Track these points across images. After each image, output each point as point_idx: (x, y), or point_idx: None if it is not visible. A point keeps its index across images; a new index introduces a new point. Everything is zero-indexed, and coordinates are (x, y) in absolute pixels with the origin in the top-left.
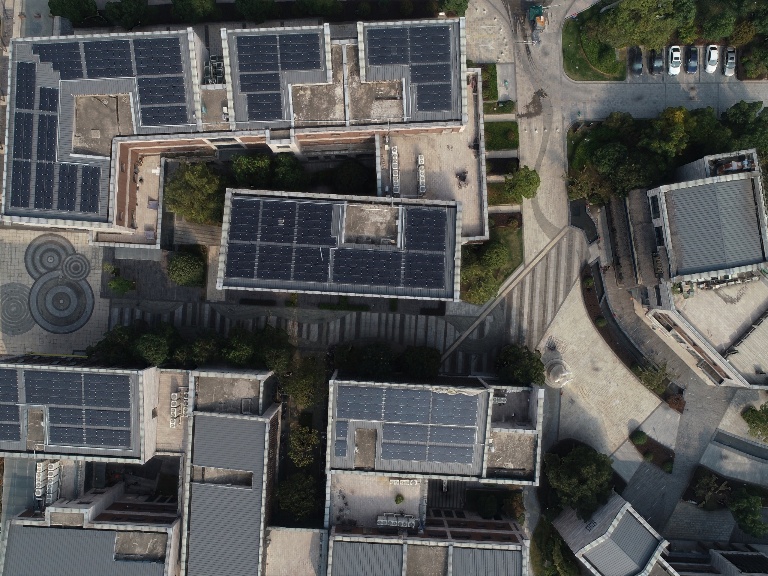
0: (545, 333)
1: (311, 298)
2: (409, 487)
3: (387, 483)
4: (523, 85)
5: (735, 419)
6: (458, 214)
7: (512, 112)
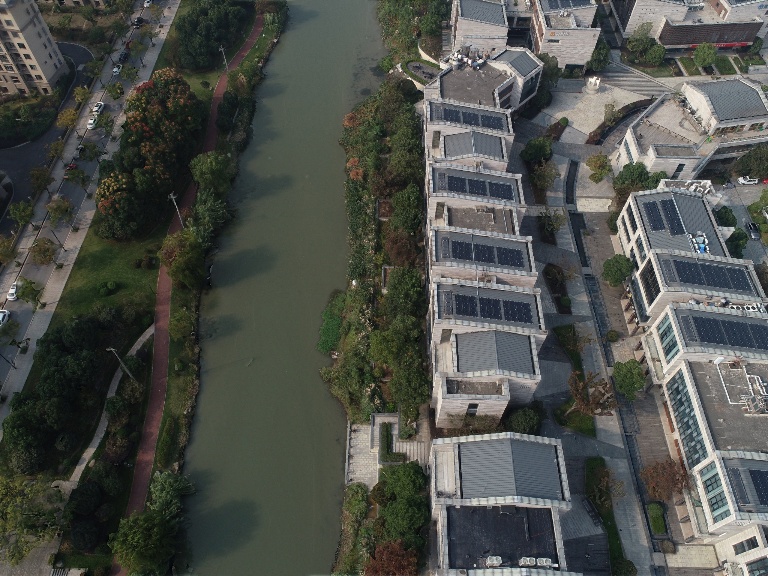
0: (614, 86)
1: (600, 7)
2: (522, 8)
3: (522, 1)
4: (760, 76)
5: (590, 171)
6: (683, 4)
7: (742, 73)
